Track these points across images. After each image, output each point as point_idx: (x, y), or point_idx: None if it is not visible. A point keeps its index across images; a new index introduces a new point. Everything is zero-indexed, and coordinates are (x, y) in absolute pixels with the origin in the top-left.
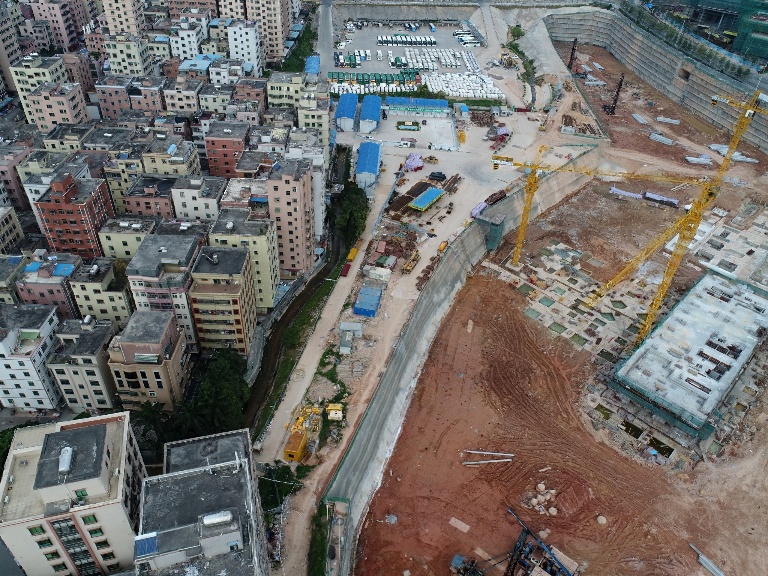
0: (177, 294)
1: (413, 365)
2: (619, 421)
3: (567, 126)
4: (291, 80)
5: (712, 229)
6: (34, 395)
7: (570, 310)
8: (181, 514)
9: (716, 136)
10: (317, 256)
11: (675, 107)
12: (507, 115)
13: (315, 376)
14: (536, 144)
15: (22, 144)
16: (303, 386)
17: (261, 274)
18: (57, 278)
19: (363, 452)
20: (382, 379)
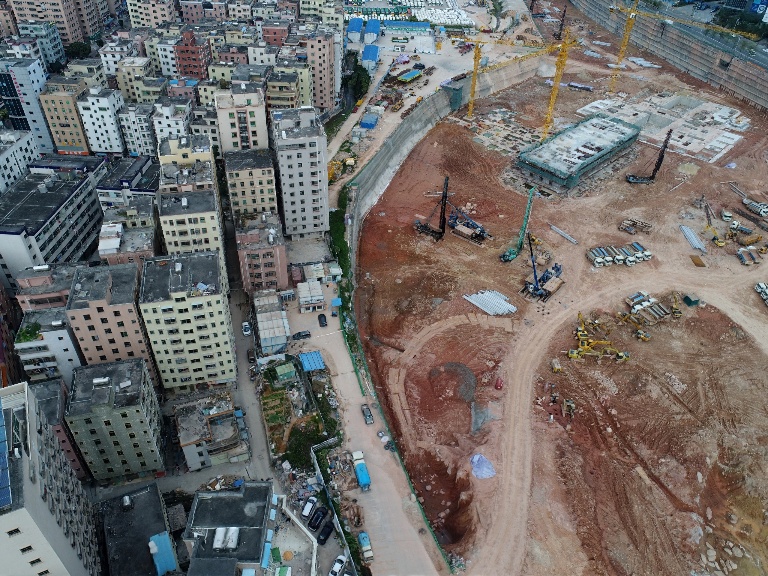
0: None
1: (398, 158)
2: (521, 183)
3: (518, 40)
4: None
5: (613, 103)
6: None
7: (502, 139)
8: None
9: (636, 53)
10: (337, 102)
11: (610, 35)
12: (475, 34)
13: (338, 152)
14: (493, 51)
15: None
16: (331, 156)
17: (304, 96)
18: None
19: (366, 182)
20: (378, 152)
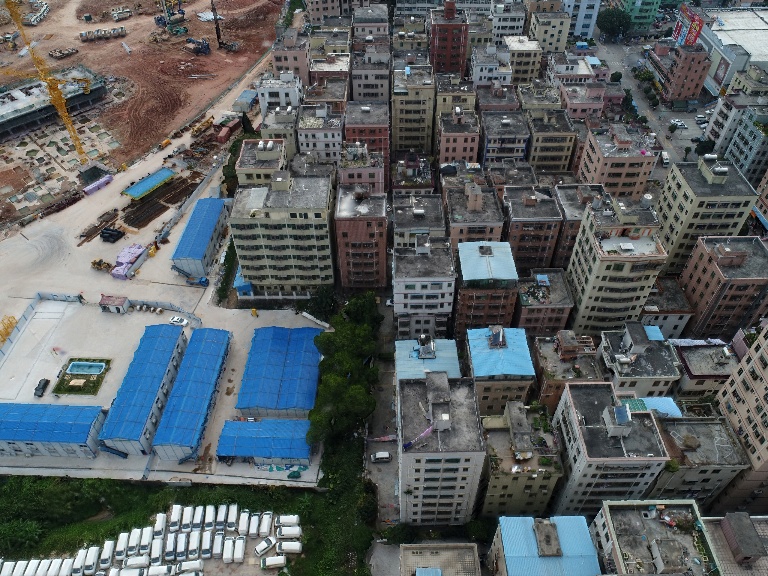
0: None
1: None
2: None
3: None
4: (292, 185)
5: None
6: None
7: None
8: None
9: None
10: None
11: None
12: None
13: None
14: None
15: None
16: None
17: None
18: None
19: None
20: None
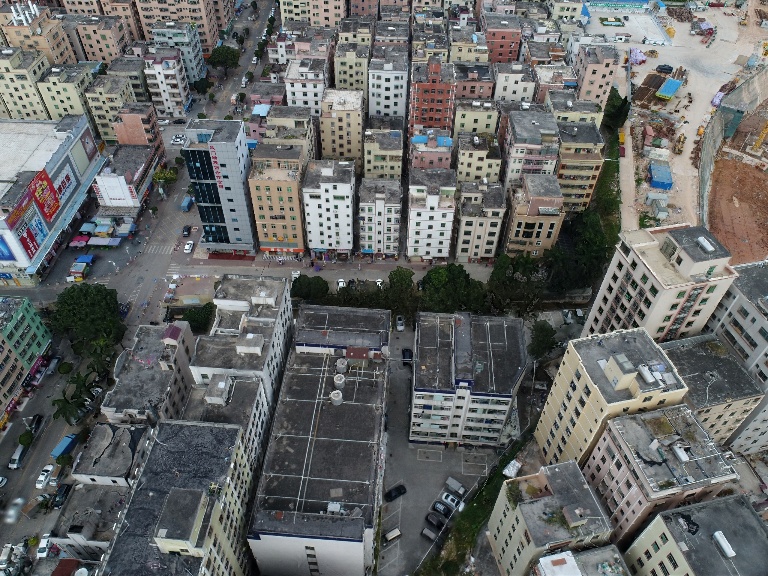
0: (549, 161)
1: None
2: None
3: None
4: None
5: None
6: (438, 244)
7: None
8: (761, 291)
9: None
10: None
11: None
12: (702, 10)
13: None
14: (742, 38)
15: (318, 38)
16: None
17: None
18: (442, 148)
19: None
20: None
